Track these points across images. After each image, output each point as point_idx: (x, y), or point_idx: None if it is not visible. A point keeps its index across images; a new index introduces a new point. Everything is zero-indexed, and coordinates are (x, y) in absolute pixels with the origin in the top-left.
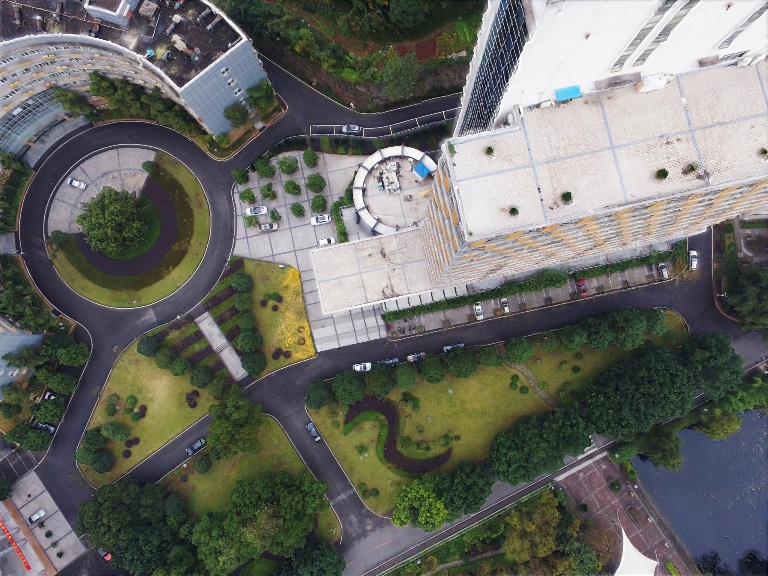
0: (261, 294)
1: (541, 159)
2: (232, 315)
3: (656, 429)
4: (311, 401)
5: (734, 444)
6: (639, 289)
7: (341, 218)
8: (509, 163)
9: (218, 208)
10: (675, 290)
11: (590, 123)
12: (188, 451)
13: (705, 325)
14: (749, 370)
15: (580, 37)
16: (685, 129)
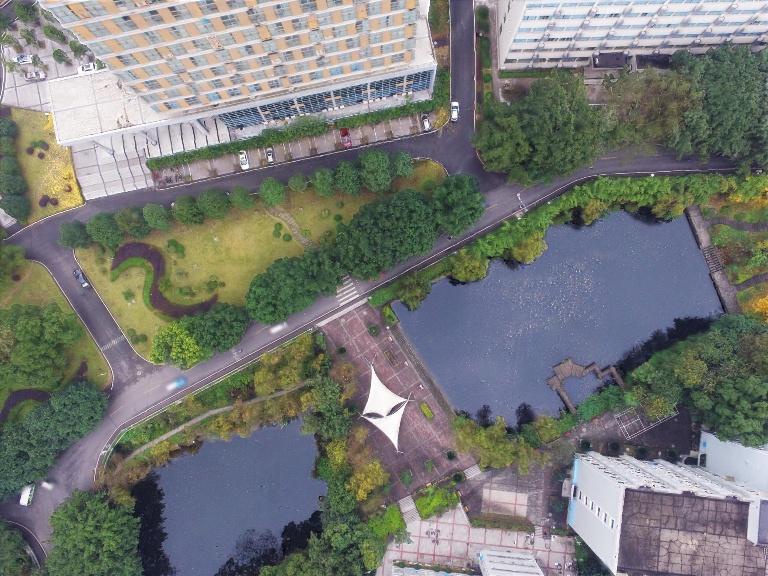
0: (28, 142)
1: None
2: None
3: None
4: (61, 237)
5: (494, 293)
6: (403, 140)
7: (103, 64)
8: None
9: None
10: (438, 141)
11: None
12: None
13: None
14: (505, 218)
15: None
16: None
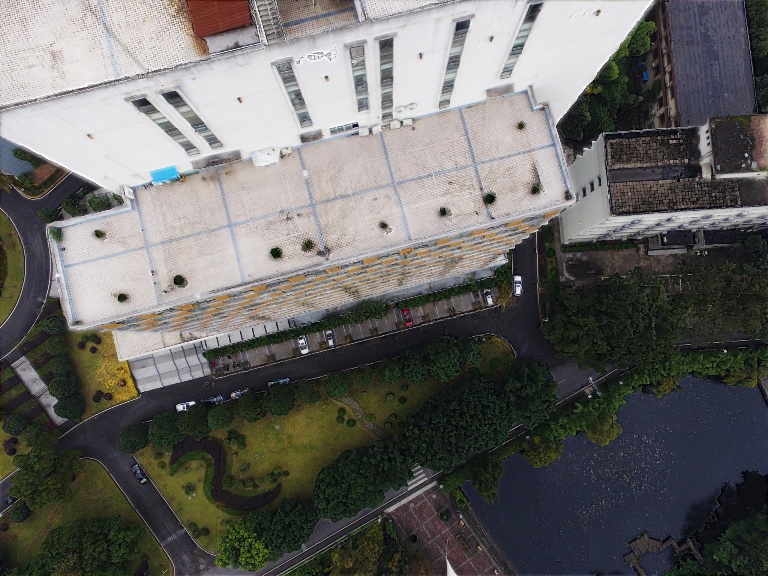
0: (79, 336)
1: (155, 240)
2: (48, 359)
3: (482, 458)
4: (121, 447)
5: (565, 468)
6: (466, 316)
7: None
8: (122, 245)
9: (33, 249)
10: (502, 316)
11: (207, 200)
12: (7, 500)
13: (532, 350)
14: (575, 394)
15: (84, 136)
16: (306, 203)
